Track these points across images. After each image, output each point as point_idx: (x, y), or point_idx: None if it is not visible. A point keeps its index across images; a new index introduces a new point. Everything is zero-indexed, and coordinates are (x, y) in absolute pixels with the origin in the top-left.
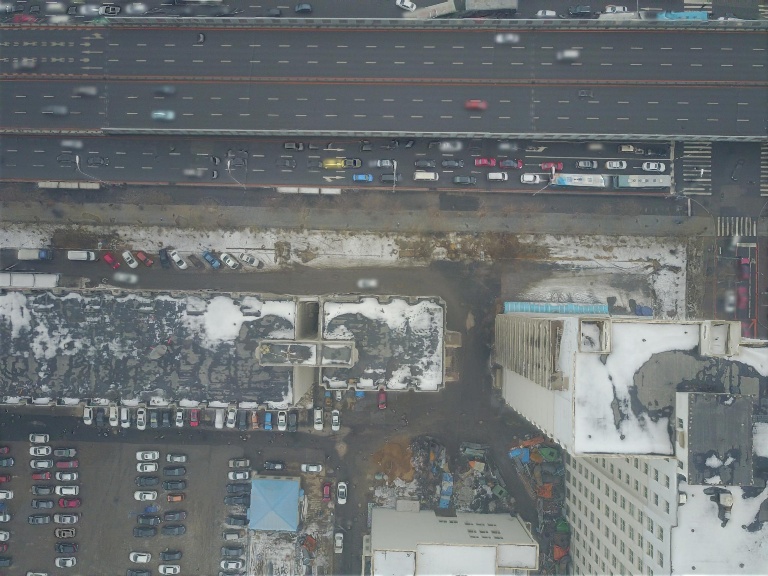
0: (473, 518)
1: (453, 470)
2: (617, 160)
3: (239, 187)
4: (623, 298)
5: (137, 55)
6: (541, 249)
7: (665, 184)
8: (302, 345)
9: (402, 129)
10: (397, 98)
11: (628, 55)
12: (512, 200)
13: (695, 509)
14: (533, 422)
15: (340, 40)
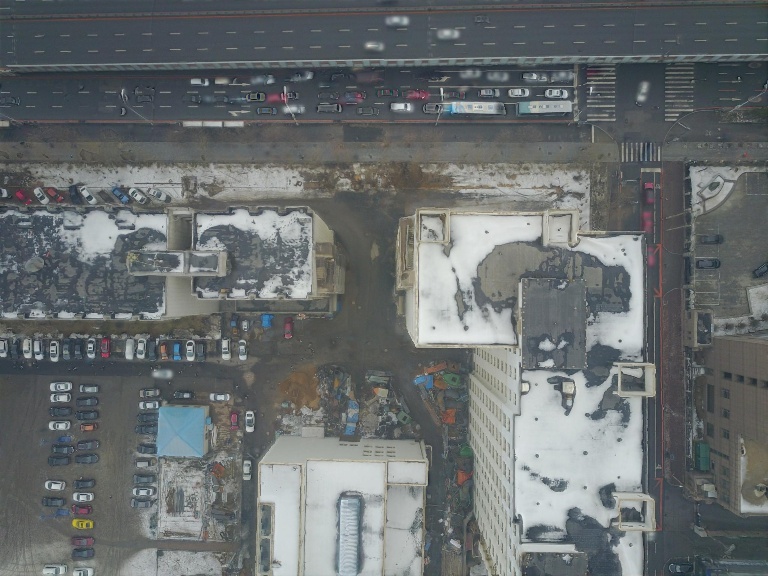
0: (375, 442)
1: (359, 398)
2: (519, 88)
3: (146, 123)
4: None
5: None
6: (444, 178)
7: (566, 110)
8: (170, 254)
9: (298, 58)
10: (295, 29)
11: None
12: (415, 130)
13: (539, 398)
14: (410, 333)
15: None
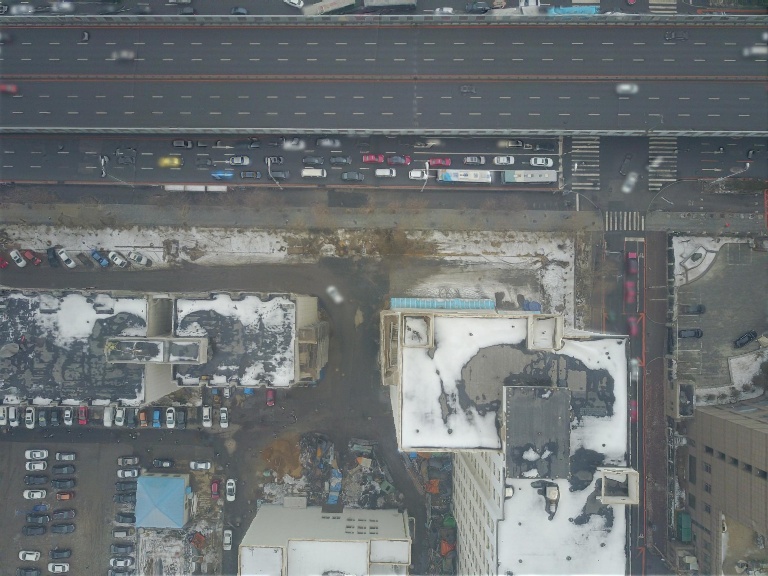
0: (358, 514)
1: (341, 466)
2: (505, 155)
3: (127, 185)
4: (511, 293)
5: (22, 54)
6: (429, 245)
7: (551, 179)
8: (150, 342)
9: (283, 126)
10: (280, 95)
11: (509, 50)
12: (400, 196)
13: (522, 502)
14: None
15: (225, 37)
